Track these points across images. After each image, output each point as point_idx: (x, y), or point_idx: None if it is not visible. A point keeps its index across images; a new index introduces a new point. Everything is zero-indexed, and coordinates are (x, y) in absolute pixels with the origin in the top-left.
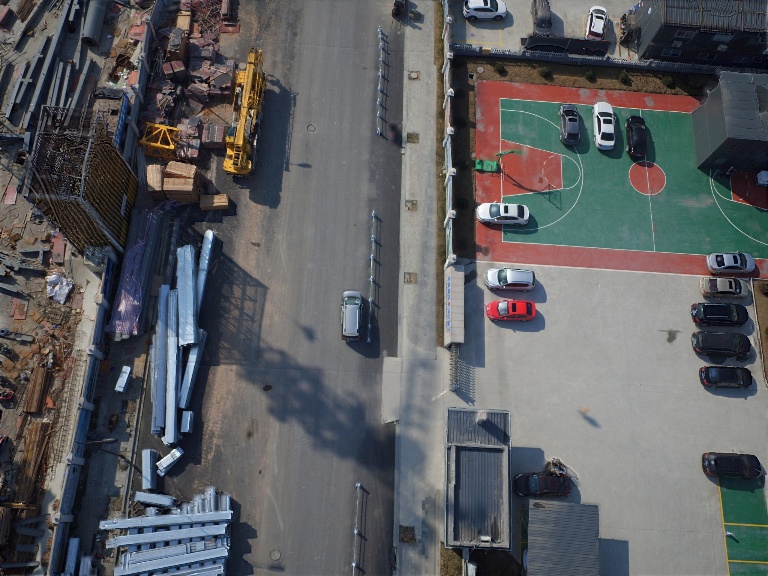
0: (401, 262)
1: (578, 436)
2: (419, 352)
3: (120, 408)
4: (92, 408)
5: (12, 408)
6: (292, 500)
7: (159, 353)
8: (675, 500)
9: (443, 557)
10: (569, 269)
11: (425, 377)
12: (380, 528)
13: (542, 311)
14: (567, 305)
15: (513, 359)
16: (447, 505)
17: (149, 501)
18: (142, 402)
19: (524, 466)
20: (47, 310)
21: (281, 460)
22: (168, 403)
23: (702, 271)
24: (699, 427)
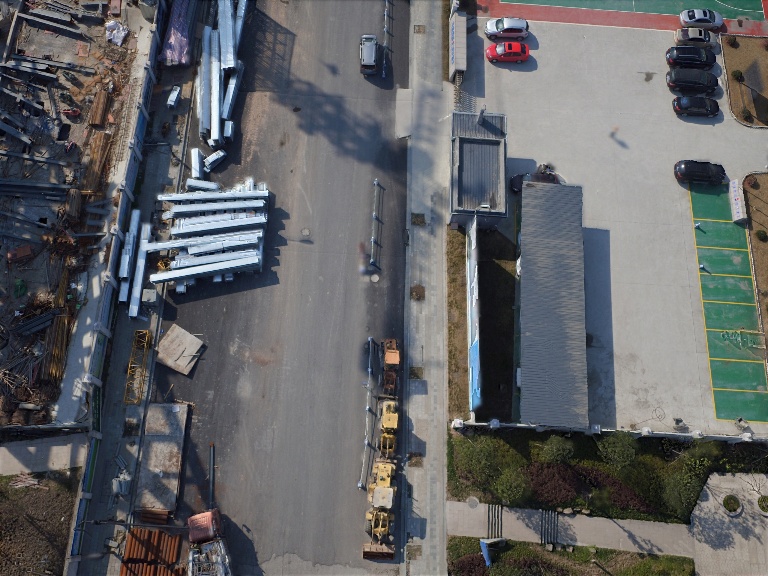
0: (411, 18)
1: (566, 151)
2: (427, 85)
3: (171, 120)
4: (148, 118)
5: (79, 123)
6: (319, 192)
7: (204, 75)
8: (650, 200)
9: (449, 235)
10: (558, 24)
11: (433, 104)
12: (395, 215)
13: (535, 56)
14: (557, 52)
15: (509, 92)
16: (452, 182)
17: (198, 186)
18: (190, 117)
19: (519, 172)
20: (107, 50)
21: (309, 163)
22: (213, 110)
23: (676, 27)
24: (672, 146)
